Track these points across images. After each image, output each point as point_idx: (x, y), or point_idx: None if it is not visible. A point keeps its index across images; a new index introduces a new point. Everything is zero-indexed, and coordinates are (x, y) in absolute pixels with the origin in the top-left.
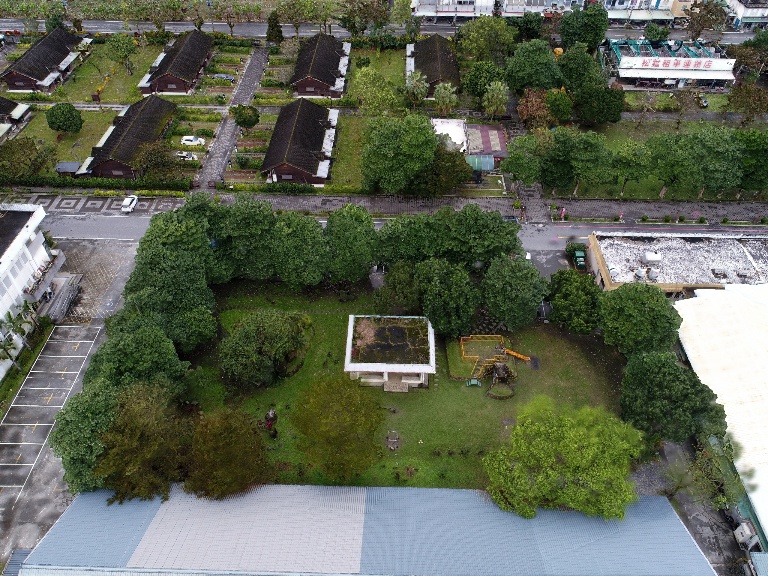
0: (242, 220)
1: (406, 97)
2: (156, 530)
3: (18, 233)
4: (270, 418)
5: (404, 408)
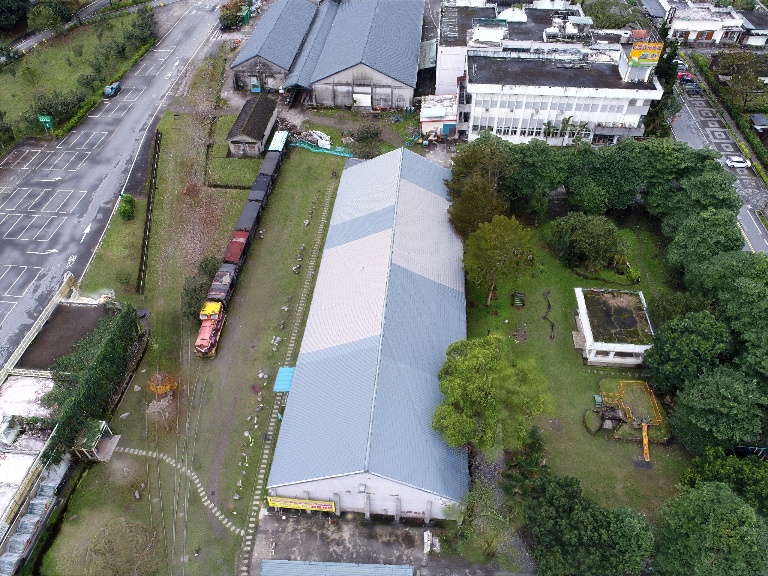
0: (701, 184)
1: None
2: (425, 192)
3: (629, 89)
4: (527, 258)
5: (557, 345)
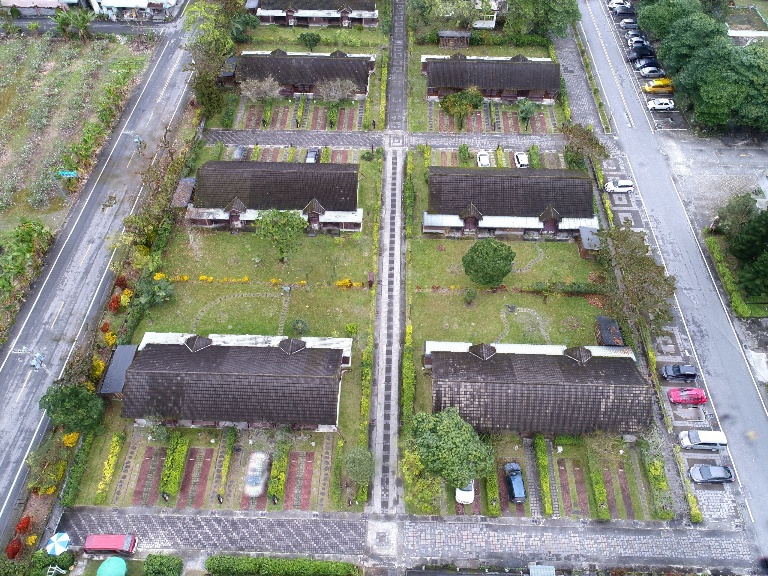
0: None
1: (425, 2)
2: None
3: None
4: None
5: None
